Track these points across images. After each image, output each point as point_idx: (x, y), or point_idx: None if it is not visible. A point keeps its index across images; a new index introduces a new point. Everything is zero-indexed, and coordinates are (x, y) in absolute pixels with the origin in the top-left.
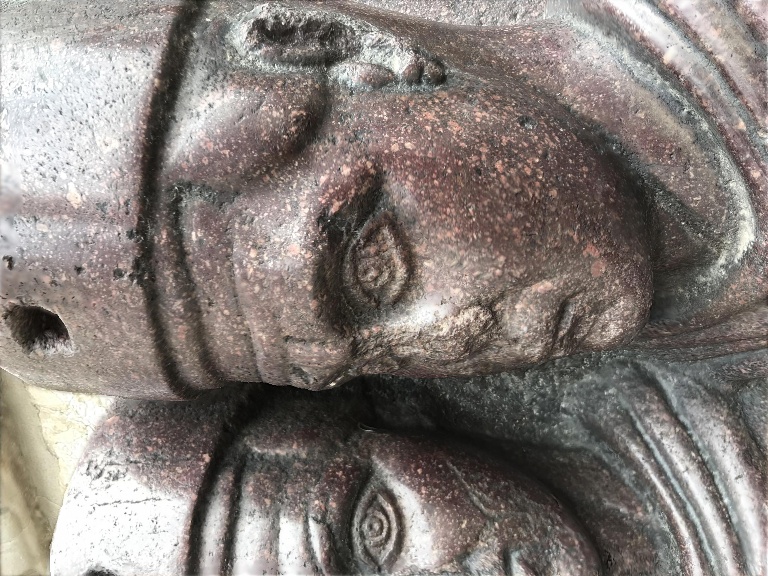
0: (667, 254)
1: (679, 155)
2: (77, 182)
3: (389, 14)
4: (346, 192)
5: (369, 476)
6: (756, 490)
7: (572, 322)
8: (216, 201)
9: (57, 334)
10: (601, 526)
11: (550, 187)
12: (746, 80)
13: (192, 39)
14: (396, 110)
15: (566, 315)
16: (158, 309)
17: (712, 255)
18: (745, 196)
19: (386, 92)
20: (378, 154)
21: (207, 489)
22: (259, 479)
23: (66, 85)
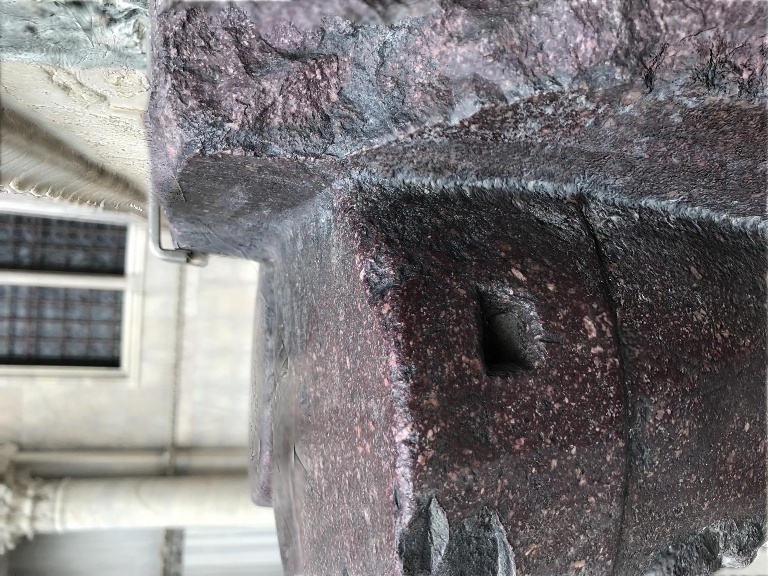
0: None
1: None
2: None
3: (758, 458)
4: None
5: None
6: None
7: None
8: None
9: None
10: None
11: None
12: None
13: None
14: None
15: None
16: None
17: None
18: None
19: None
20: None
21: None
22: None
23: None
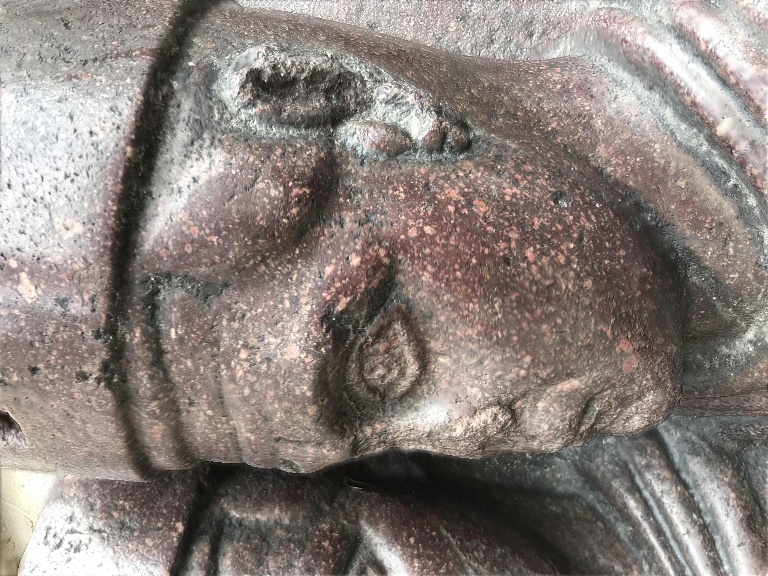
0: (692, 327)
1: (720, 230)
2: (30, 272)
3: (401, 50)
4: (355, 286)
5: (357, 544)
6: (759, 559)
7: (596, 418)
8: (200, 293)
9: (8, 424)
10: None
11: (585, 277)
12: None
13: (172, 90)
14: (414, 185)
15: (590, 410)
16: (129, 410)
17: (740, 329)
18: None
19: (403, 162)
20: (393, 240)
21: (180, 564)
22: (238, 550)
23: (15, 151)
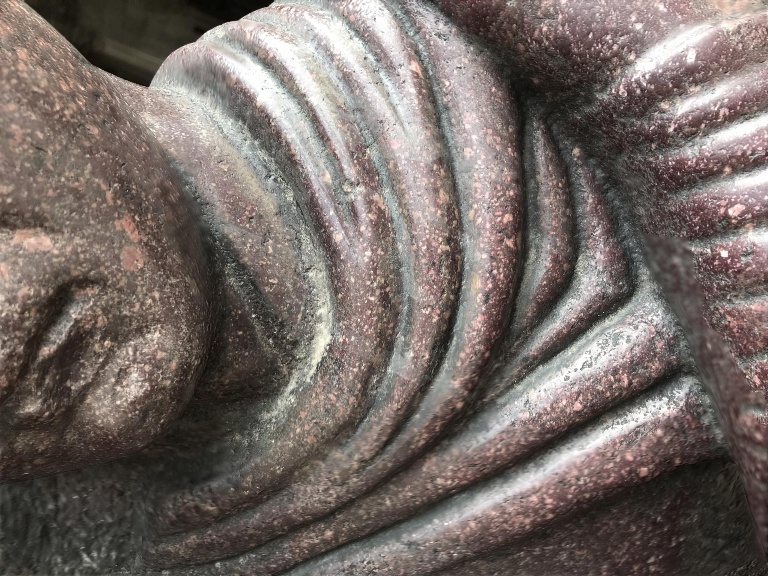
0: (229, 359)
1: (259, 222)
2: None
3: None
4: None
5: None
6: None
7: (70, 334)
8: None
9: None
10: None
11: (90, 120)
12: (335, 126)
13: None
14: None
15: (62, 320)
16: None
17: (282, 379)
18: (324, 283)
19: None
20: None
21: None
22: None
23: None
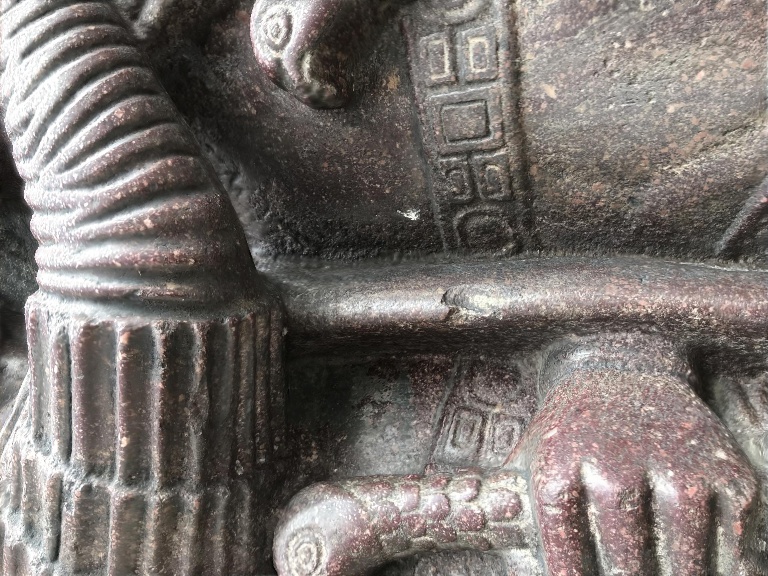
0: (9, 144)
1: None
2: None
3: None
4: None
5: None
6: None
7: None
8: None
9: None
10: (15, 349)
11: None
12: None
13: None
14: None
15: None
16: None
17: None
18: None
19: None
20: None
21: None
22: None
23: None
